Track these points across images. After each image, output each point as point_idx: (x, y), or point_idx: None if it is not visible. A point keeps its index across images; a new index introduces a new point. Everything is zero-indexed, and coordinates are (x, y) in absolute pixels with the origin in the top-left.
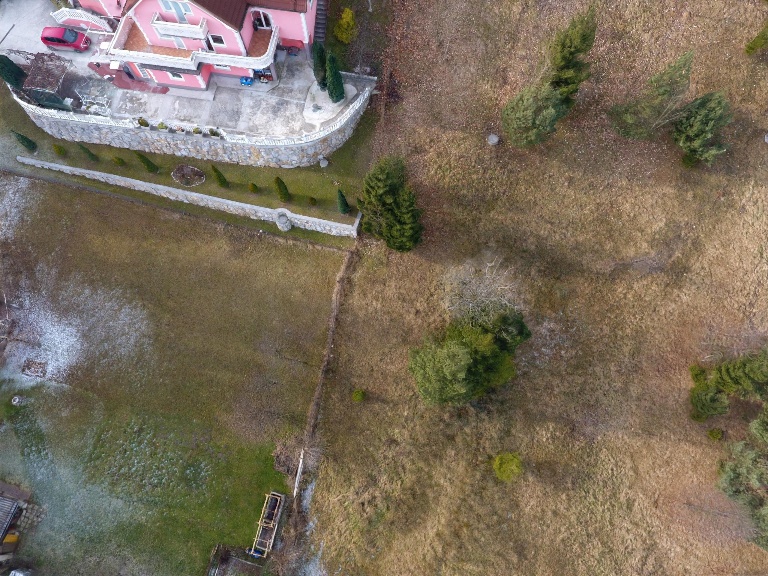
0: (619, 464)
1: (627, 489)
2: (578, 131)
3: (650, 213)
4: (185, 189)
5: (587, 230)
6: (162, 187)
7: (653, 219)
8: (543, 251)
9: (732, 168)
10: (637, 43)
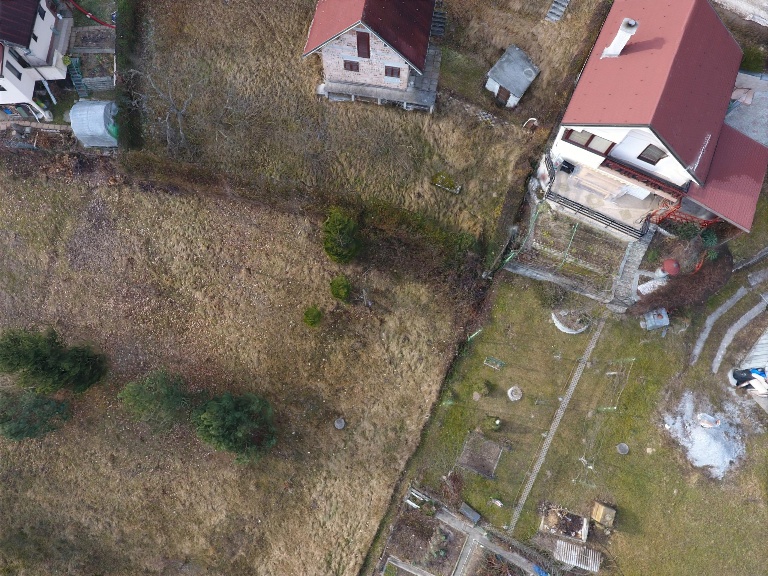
0: None
1: None
2: (122, 403)
3: (209, 502)
4: None
5: (135, 519)
6: None
7: (211, 510)
8: (83, 543)
9: (302, 454)
10: (188, 302)
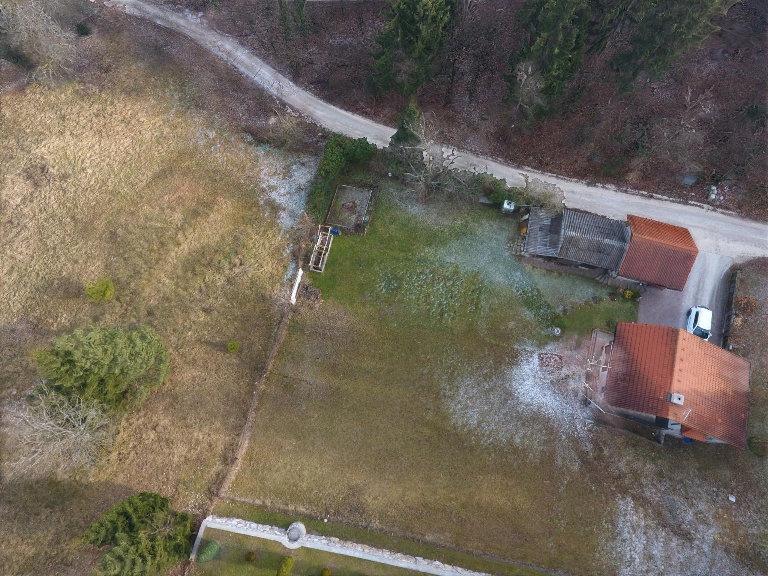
0: (6, 300)
1: (8, 282)
2: None
3: None
4: (416, 572)
5: None
6: (446, 574)
7: None
8: None
9: None
10: None
